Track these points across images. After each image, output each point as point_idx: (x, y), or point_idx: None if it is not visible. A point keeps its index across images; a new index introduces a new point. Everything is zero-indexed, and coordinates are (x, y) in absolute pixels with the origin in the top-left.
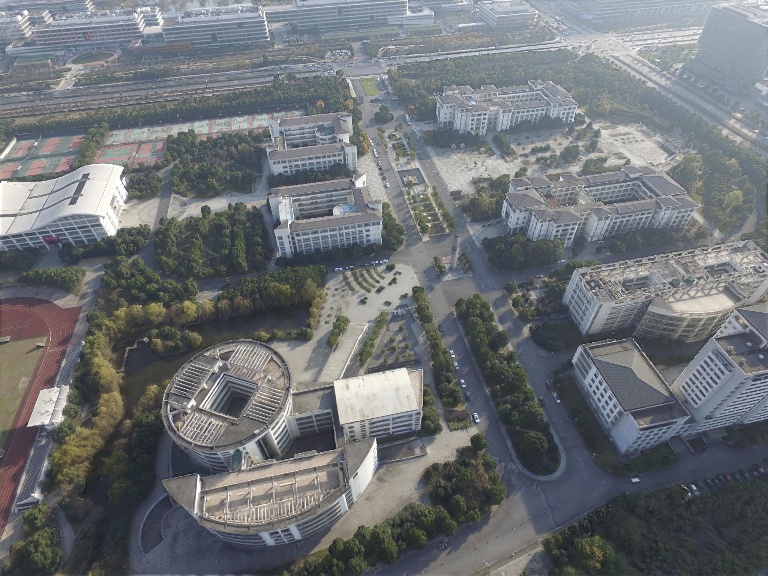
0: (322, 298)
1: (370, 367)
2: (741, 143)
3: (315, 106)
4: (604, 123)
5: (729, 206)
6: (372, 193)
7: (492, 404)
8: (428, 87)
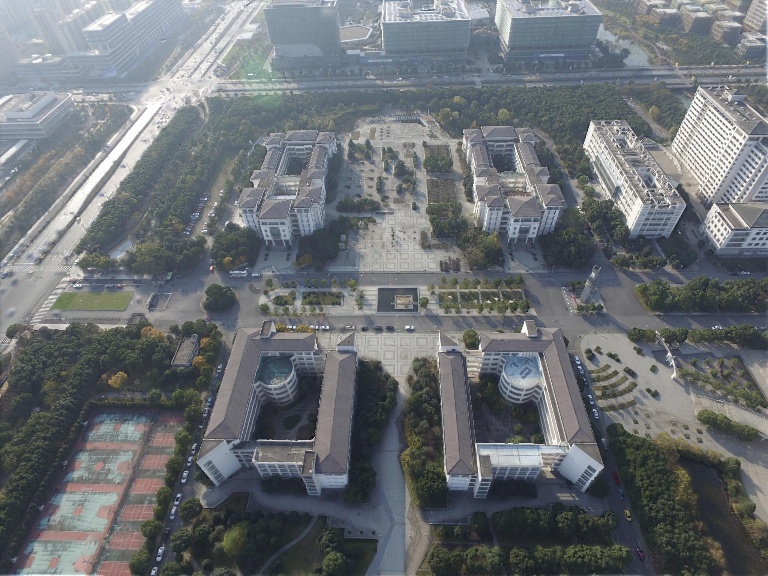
0: None
1: None
2: (428, 88)
3: (100, 393)
4: (347, 136)
5: None
6: (424, 349)
7: None
8: (177, 232)
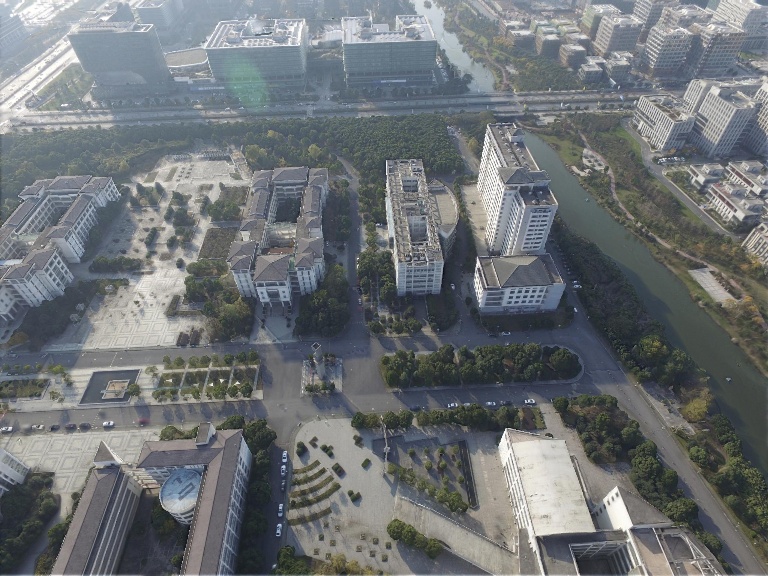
0: (345, 560)
1: (468, 502)
2: (247, 120)
3: None
4: (141, 177)
5: (315, 159)
6: (114, 452)
7: (514, 384)
8: None
